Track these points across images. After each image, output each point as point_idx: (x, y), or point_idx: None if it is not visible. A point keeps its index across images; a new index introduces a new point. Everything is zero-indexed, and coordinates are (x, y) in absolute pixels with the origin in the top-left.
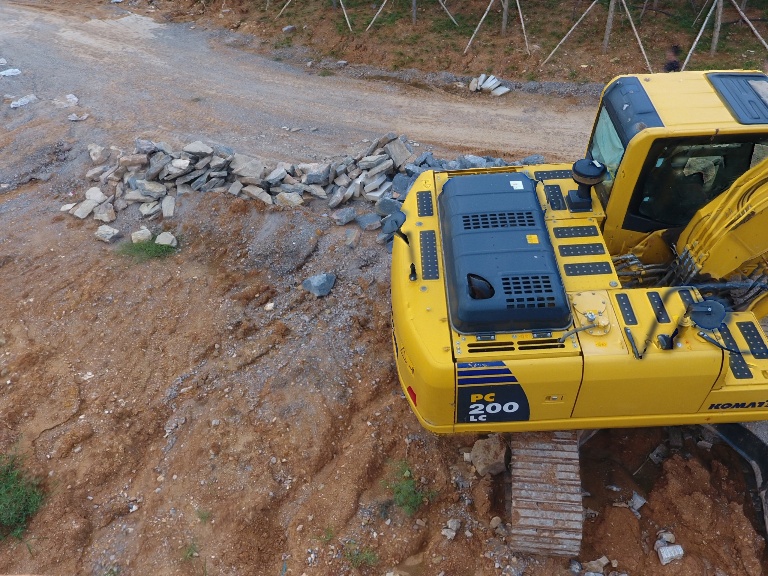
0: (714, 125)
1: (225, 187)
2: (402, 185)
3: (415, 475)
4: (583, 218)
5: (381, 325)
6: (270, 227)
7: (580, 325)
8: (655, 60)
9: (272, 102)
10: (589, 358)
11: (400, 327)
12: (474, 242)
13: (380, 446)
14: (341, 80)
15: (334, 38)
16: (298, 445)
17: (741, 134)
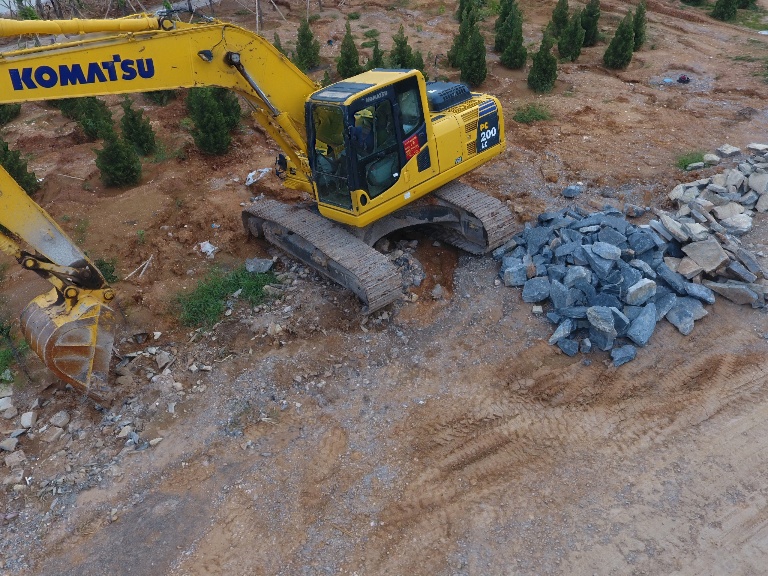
0: None
1: None
2: None
3: None
4: None
5: (508, 194)
6: None
7: None
8: None
9: None
10: None
11: None
12: None
13: None
14: None
15: None
16: None
17: None
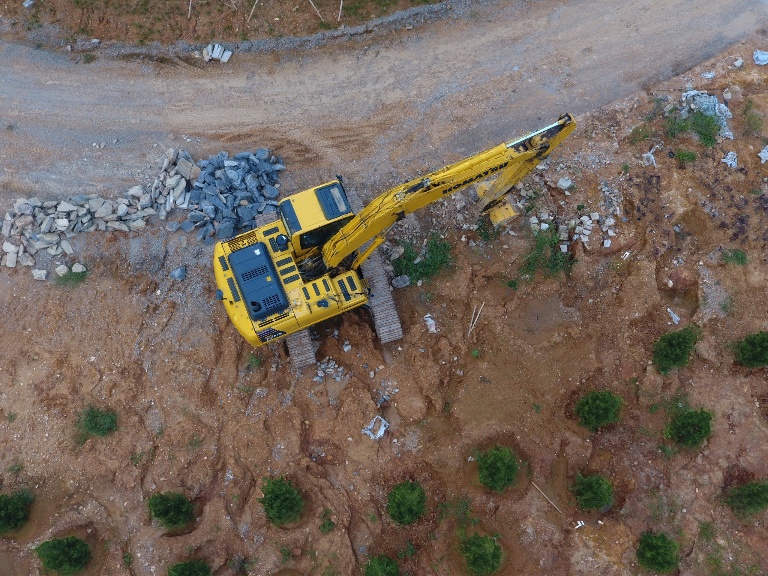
0: (319, 224)
1: (95, 225)
2: (197, 197)
3: (255, 352)
4: (286, 254)
5: None
6: (136, 246)
7: (293, 306)
8: (323, 1)
9: (69, 114)
10: (298, 317)
11: (234, 323)
12: (249, 287)
13: (238, 346)
14: (105, 66)
15: (76, 11)
16: (205, 356)
17: (328, 224)
